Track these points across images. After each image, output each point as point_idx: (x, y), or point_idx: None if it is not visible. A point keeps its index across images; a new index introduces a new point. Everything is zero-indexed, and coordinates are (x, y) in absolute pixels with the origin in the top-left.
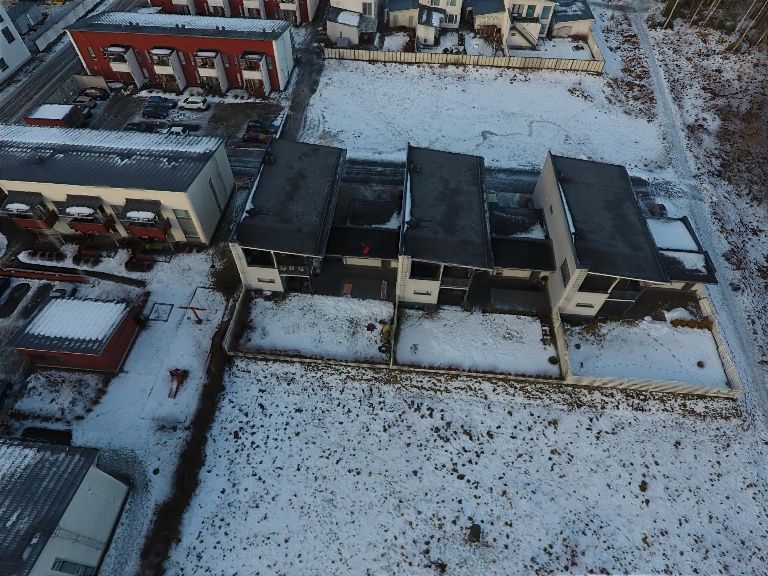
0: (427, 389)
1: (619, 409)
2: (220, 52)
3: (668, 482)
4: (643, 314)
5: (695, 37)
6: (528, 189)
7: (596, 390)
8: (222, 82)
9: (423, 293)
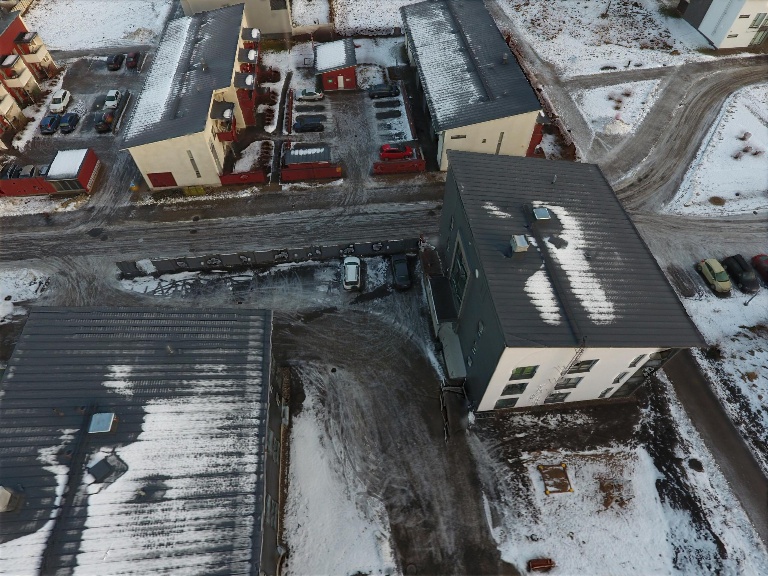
0: None
1: None
2: None
3: None
4: None
5: None
6: None
7: None
8: None
9: None
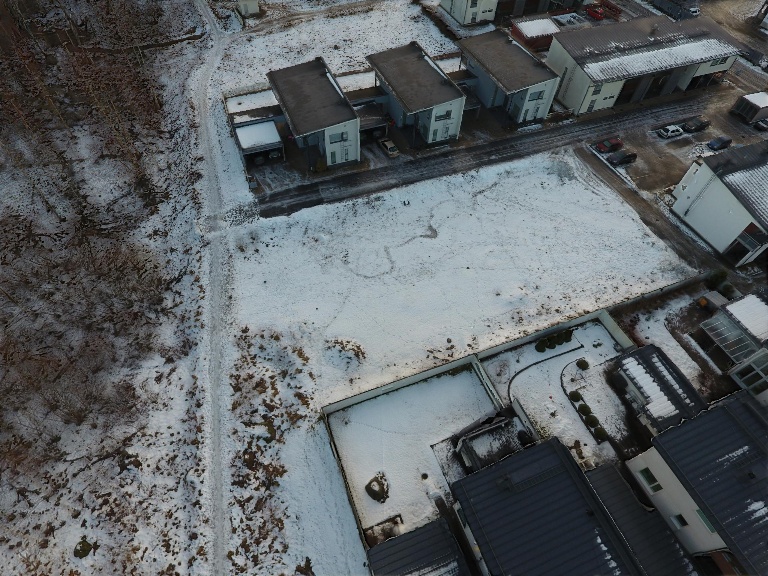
0: None
1: None
2: None
3: None
4: None
5: None
6: (366, 175)
7: None
8: None
9: None
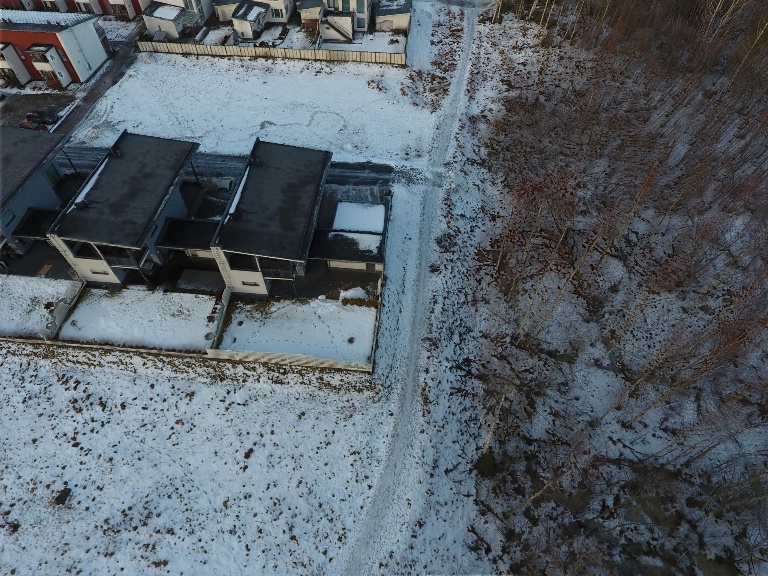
0: (81, 363)
1: (259, 382)
2: (11, 44)
3: (275, 450)
4: (319, 293)
5: (518, 31)
6: None
7: (240, 364)
8: (18, 74)
9: (101, 272)
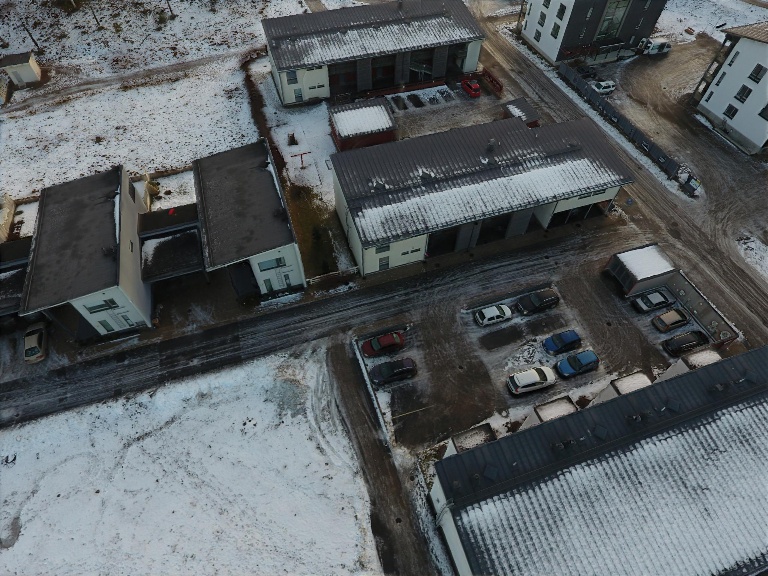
0: None
1: None
2: None
3: None
4: None
5: None
6: None
7: None
8: None
9: None
